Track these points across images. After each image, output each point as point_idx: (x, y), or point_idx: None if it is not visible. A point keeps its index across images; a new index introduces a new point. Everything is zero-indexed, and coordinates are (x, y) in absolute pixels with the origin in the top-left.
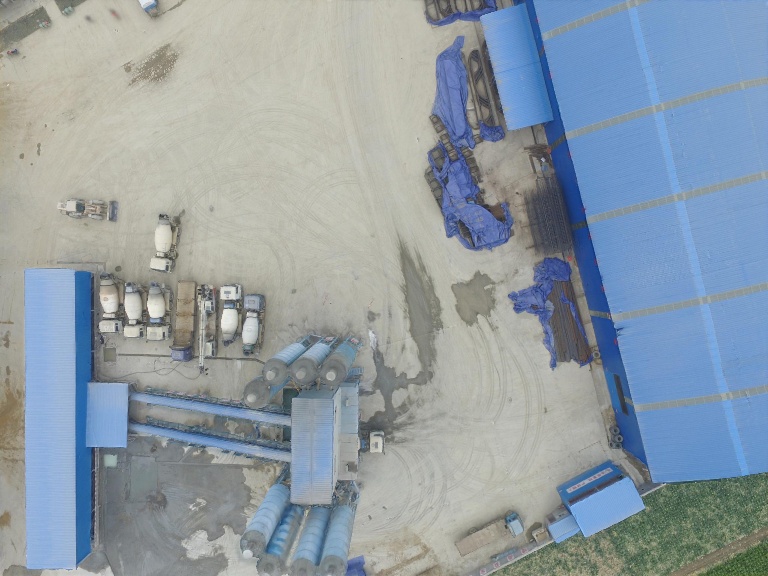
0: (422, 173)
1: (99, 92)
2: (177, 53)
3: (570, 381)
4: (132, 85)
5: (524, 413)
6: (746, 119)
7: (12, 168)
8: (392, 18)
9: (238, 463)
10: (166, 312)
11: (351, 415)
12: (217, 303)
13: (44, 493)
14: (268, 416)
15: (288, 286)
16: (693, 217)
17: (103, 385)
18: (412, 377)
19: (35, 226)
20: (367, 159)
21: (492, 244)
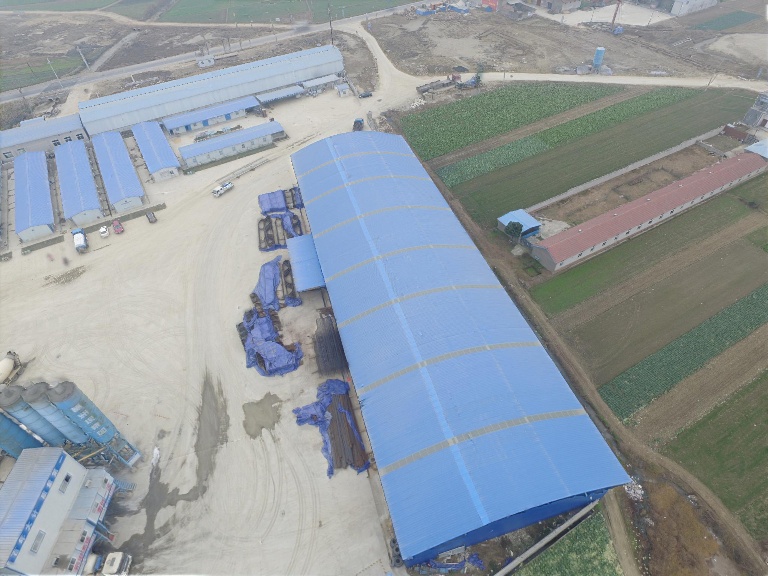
0: None
1: (18, 291)
2: (86, 270)
3: (347, 489)
4: (44, 286)
5: (296, 528)
6: (436, 261)
7: None
8: (237, 249)
9: None
10: None
11: (87, 498)
12: None
13: None
14: None
15: None
16: (406, 311)
17: None
18: (184, 493)
19: None
20: (197, 320)
21: (283, 371)
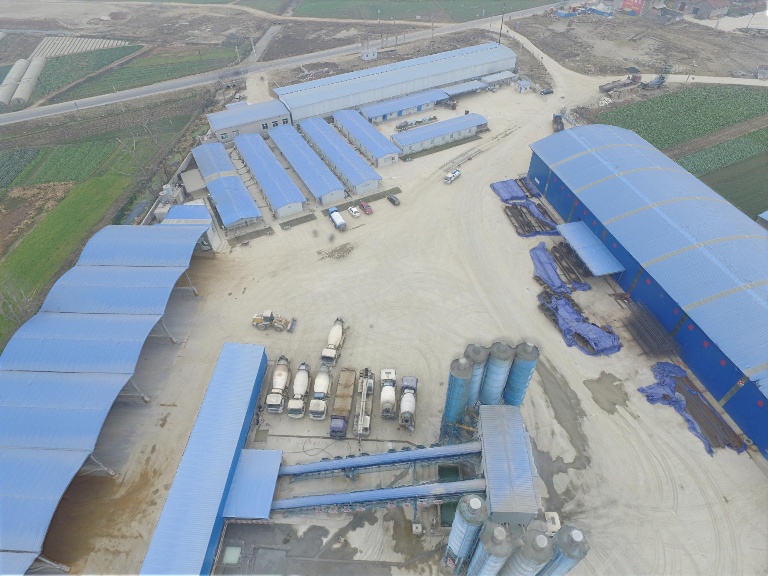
0: (536, 307)
1: (297, 263)
2: (354, 247)
3: (736, 468)
4: (321, 260)
5: (703, 502)
6: (762, 251)
7: (220, 300)
8: (495, 234)
9: (386, 560)
10: (327, 394)
11: None
12: (373, 389)
13: (166, 559)
14: (446, 447)
15: (436, 380)
16: (764, 297)
17: (257, 452)
18: (569, 461)
19: (225, 335)
20: (492, 299)
21: (608, 351)
